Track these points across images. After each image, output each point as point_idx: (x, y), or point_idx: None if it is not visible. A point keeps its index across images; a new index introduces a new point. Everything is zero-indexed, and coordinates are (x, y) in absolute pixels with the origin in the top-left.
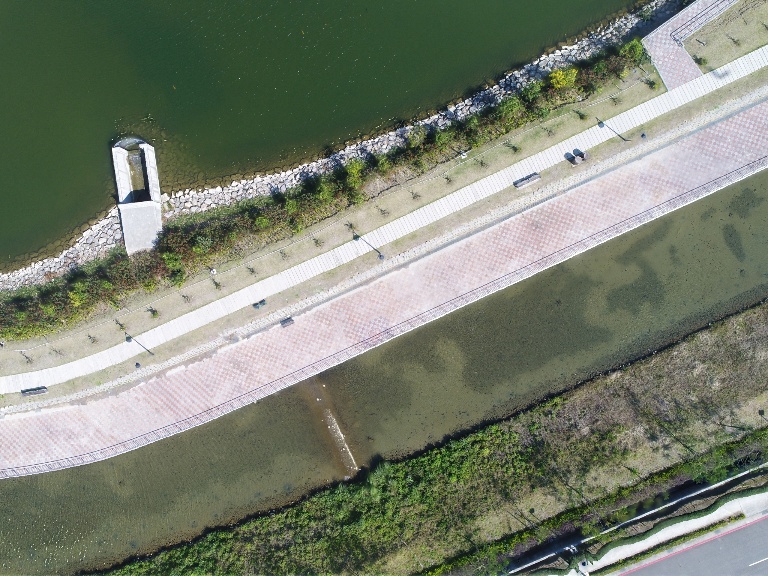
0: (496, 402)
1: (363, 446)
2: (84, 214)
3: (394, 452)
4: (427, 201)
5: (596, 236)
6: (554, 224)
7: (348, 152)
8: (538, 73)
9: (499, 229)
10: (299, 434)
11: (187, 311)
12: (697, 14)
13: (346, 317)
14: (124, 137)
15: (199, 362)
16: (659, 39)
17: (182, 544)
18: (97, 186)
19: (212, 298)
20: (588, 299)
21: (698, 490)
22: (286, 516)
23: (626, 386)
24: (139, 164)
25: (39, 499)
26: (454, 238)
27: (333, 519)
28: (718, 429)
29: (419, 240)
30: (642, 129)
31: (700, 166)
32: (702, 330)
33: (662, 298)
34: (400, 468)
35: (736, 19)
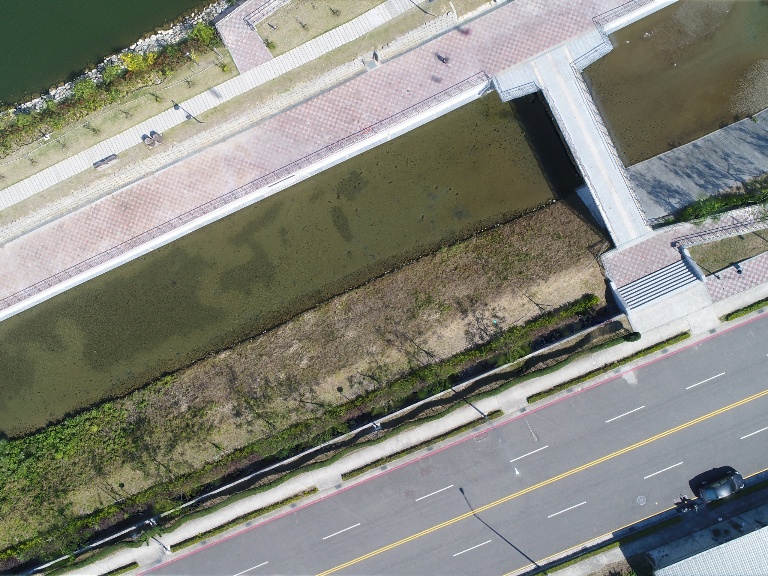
0: (115, 381)
1: None
2: None
3: (17, 430)
4: (12, 182)
5: (183, 217)
6: (143, 205)
7: None
8: None
9: (90, 210)
10: None
11: None
12: None
13: None
14: None
15: None
16: (233, 23)
17: None
18: None
19: None
20: (202, 280)
21: (272, 465)
22: None
23: (230, 365)
24: None
25: None
26: (47, 219)
27: None
28: (299, 406)
29: (5, 220)
30: (215, 111)
31: (281, 148)
32: (308, 310)
33: (273, 279)
34: (17, 445)
35: (305, 4)
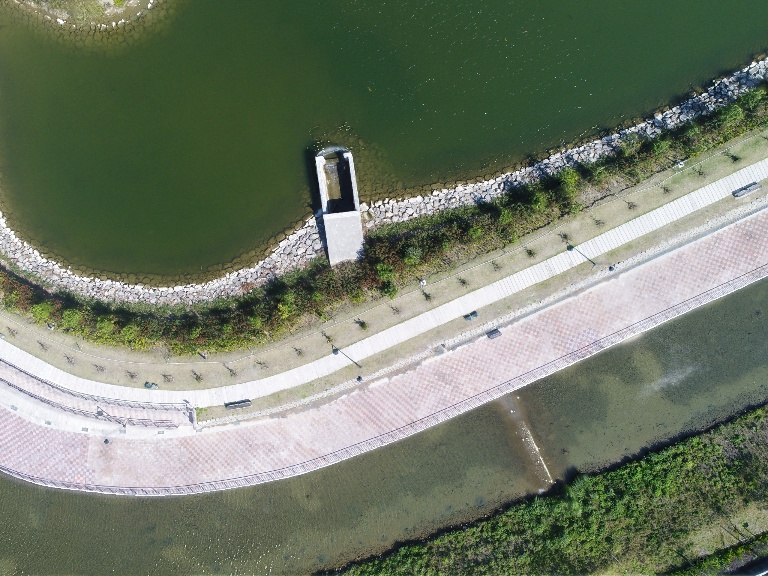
0: (694, 414)
1: (558, 459)
2: (278, 224)
3: (590, 465)
4: (643, 211)
5: None
6: None
7: (553, 161)
8: (750, 81)
9: (712, 239)
10: (491, 446)
11: (396, 323)
12: None
13: (554, 328)
14: (320, 145)
15: (403, 374)
16: None
17: (372, 558)
18: (291, 195)
19: (422, 309)
20: None
21: None
22: (481, 530)
23: None
24: (335, 173)
25: (224, 513)
26: (665, 248)
27: (533, 533)
28: None
29: (635, 250)
30: None
31: None
32: None
33: None
34: (599, 481)
35: None
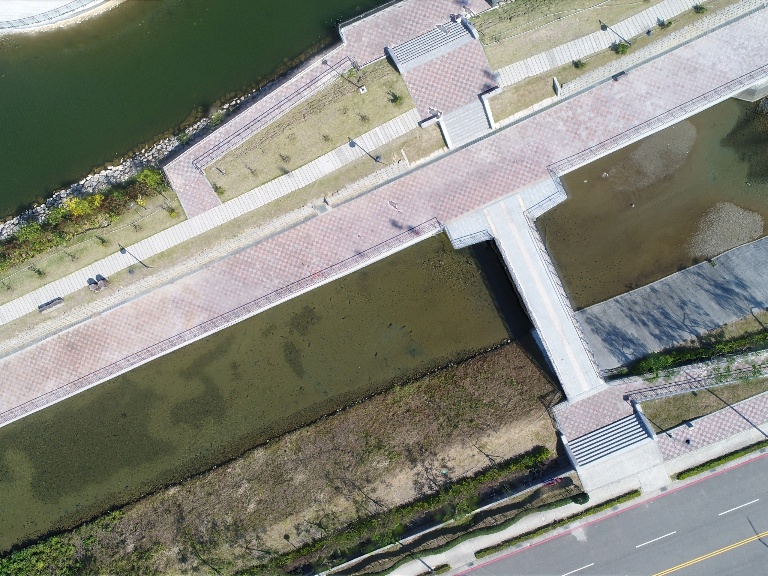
0: (63, 513)
1: None
2: None
3: None
4: None
5: (130, 358)
6: (89, 345)
7: None
8: (80, 194)
9: (36, 349)
10: None
11: None
12: (219, 142)
13: None
14: None
15: None
16: (181, 167)
17: None
18: None
19: None
20: (152, 413)
21: None
22: None
23: (179, 502)
24: None
25: None
26: None
27: None
28: (245, 552)
29: None
30: (162, 256)
31: (230, 291)
32: (259, 447)
33: (224, 413)
34: None
35: (254, 149)
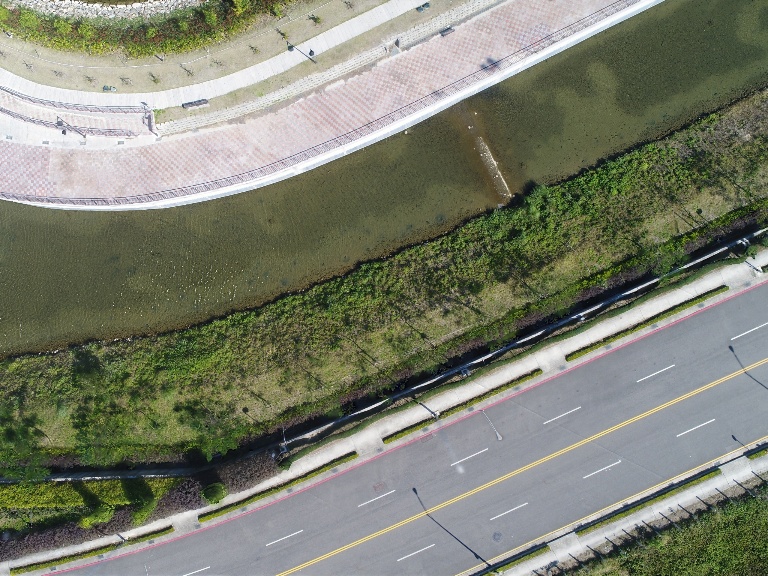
0: (649, 124)
1: (516, 173)
2: None
3: (547, 178)
4: None
5: None
6: None
7: None
8: None
9: None
10: (450, 164)
11: (350, 17)
12: None
13: (507, 25)
14: None
15: (358, 76)
16: None
17: (334, 278)
18: None
19: (375, 3)
20: (740, 17)
21: None
22: (441, 243)
23: None
24: None
25: (187, 240)
26: None
27: (492, 239)
28: None
29: None
30: None
31: None
32: None
33: None
34: (556, 190)
35: None
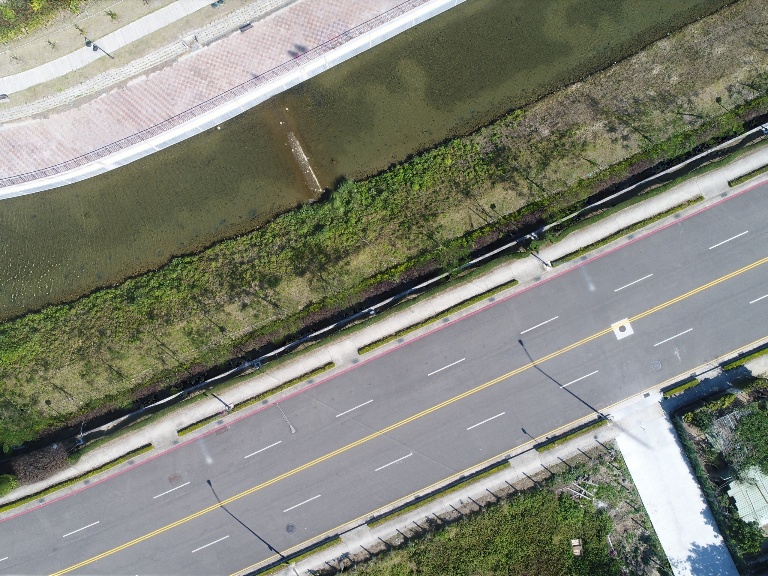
0: (458, 120)
1: (327, 168)
2: None
3: (358, 173)
4: None
5: None
6: None
7: None
8: None
9: None
10: (263, 159)
11: (146, 13)
12: None
13: (305, 21)
14: None
15: (160, 71)
16: None
17: (148, 273)
18: None
19: None
20: (547, 14)
21: (657, 174)
22: (251, 237)
23: (586, 93)
24: None
25: (5, 234)
26: None
27: (297, 233)
28: (676, 118)
29: None
30: None
31: None
32: (661, 39)
33: (621, 11)
34: (363, 185)
35: None
